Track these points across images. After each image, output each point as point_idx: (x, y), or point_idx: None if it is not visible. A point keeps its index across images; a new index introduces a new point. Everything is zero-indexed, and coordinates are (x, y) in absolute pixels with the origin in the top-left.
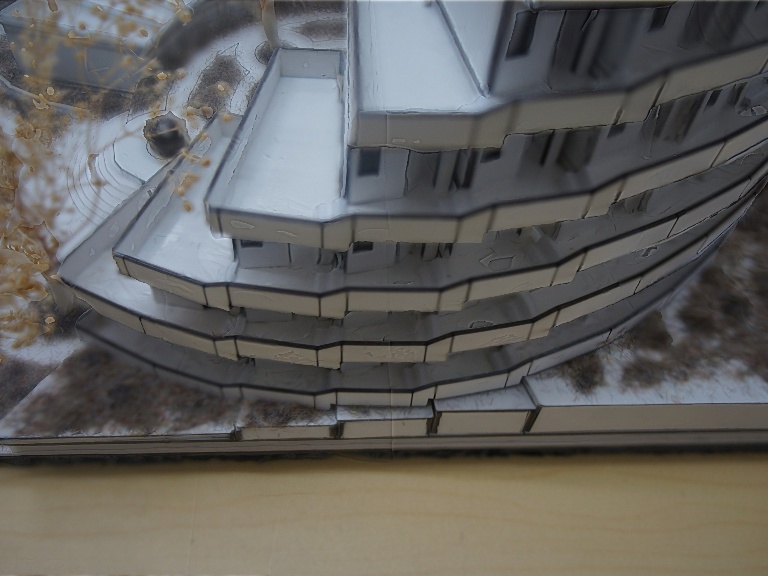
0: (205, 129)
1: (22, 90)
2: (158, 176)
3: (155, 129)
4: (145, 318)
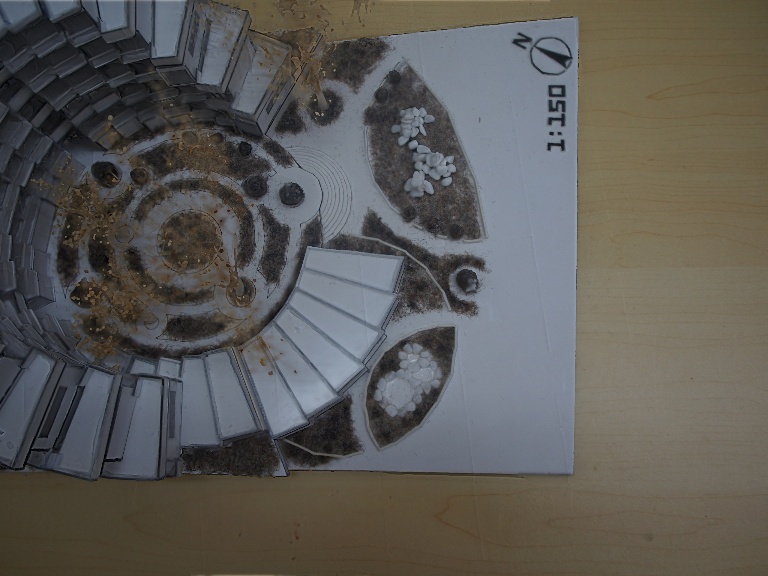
0: (225, 75)
1: (397, 248)
2: (261, 99)
3: (293, 185)
4: (252, 30)
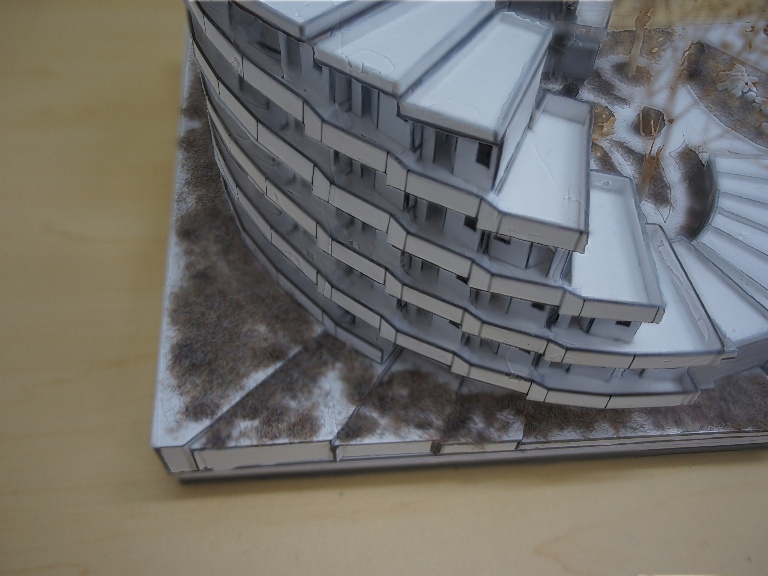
0: None
1: None
2: (607, 17)
3: None
4: None
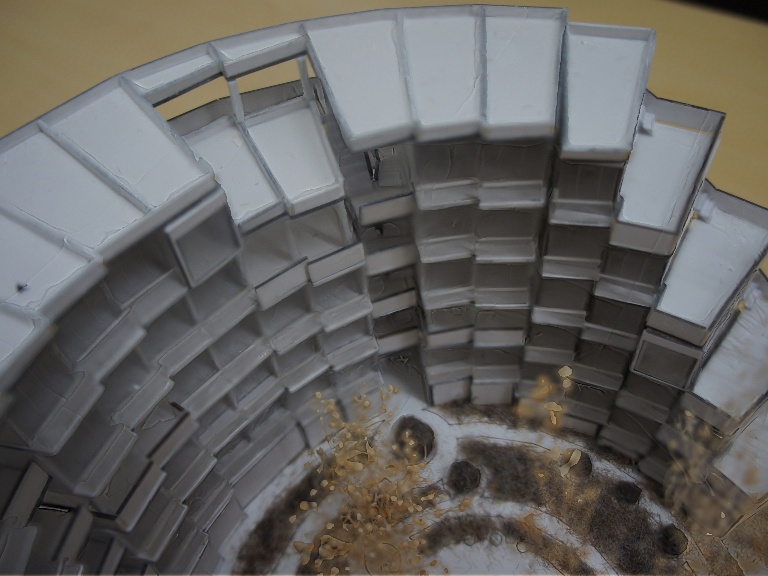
0: (754, 407)
1: None
2: None
3: None
4: None
